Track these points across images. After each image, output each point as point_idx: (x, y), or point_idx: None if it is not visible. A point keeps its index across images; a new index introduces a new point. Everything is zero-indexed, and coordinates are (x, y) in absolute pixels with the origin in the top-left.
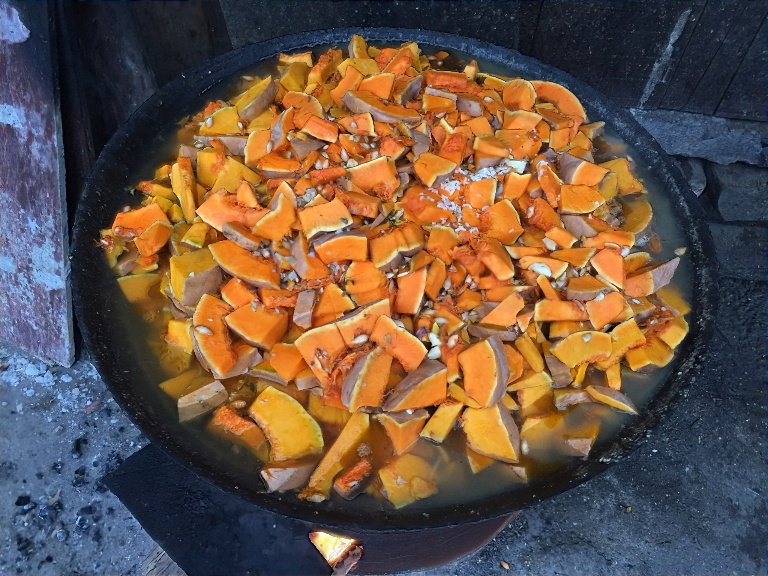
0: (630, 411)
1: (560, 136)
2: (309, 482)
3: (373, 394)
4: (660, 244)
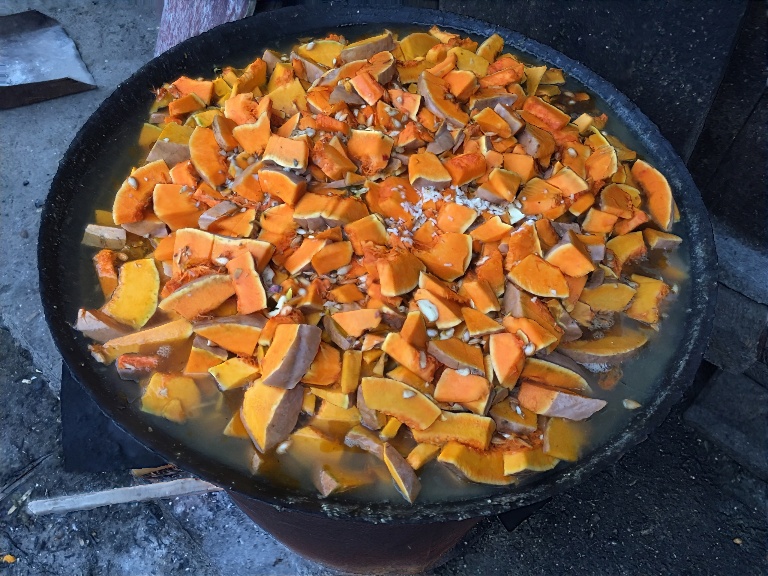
0: (406, 494)
1: (601, 219)
2: (106, 343)
3: (191, 307)
4: (615, 383)
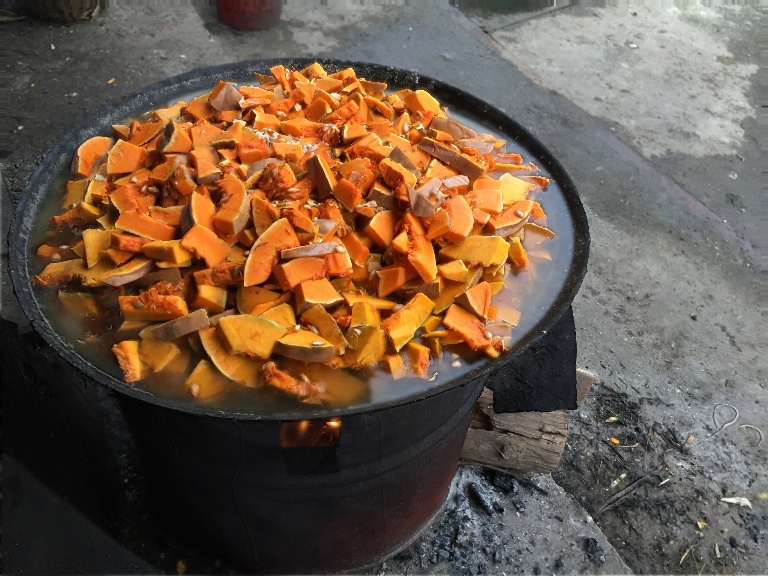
0: None
1: None
2: None
3: None
4: None
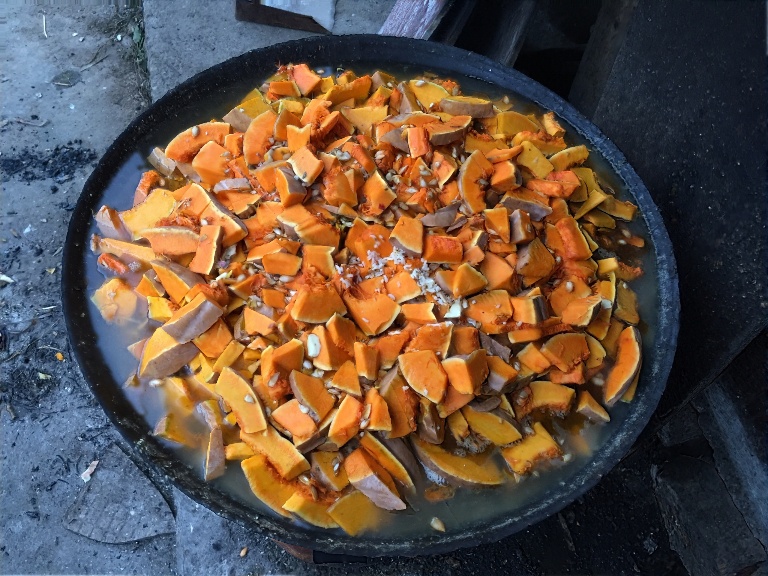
0: (206, 471)
1: (536, 358)
2: (105, 238)
3: (160, 245)
4: (439, 499)
